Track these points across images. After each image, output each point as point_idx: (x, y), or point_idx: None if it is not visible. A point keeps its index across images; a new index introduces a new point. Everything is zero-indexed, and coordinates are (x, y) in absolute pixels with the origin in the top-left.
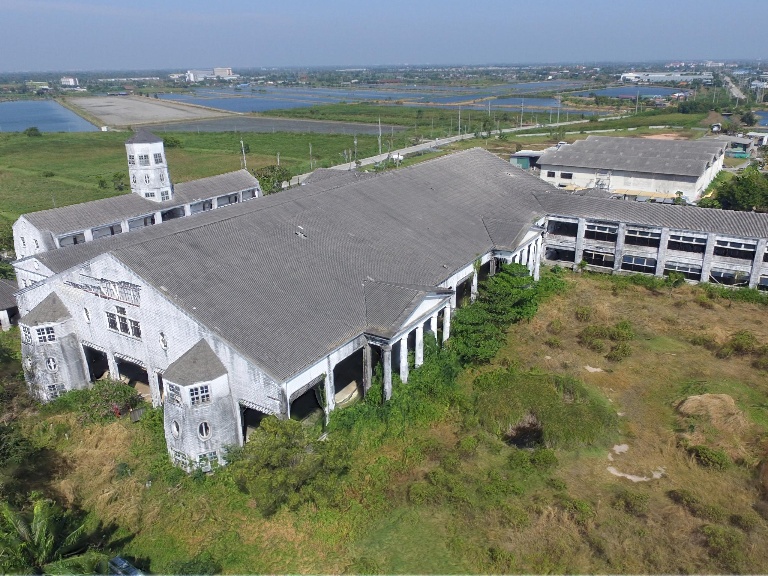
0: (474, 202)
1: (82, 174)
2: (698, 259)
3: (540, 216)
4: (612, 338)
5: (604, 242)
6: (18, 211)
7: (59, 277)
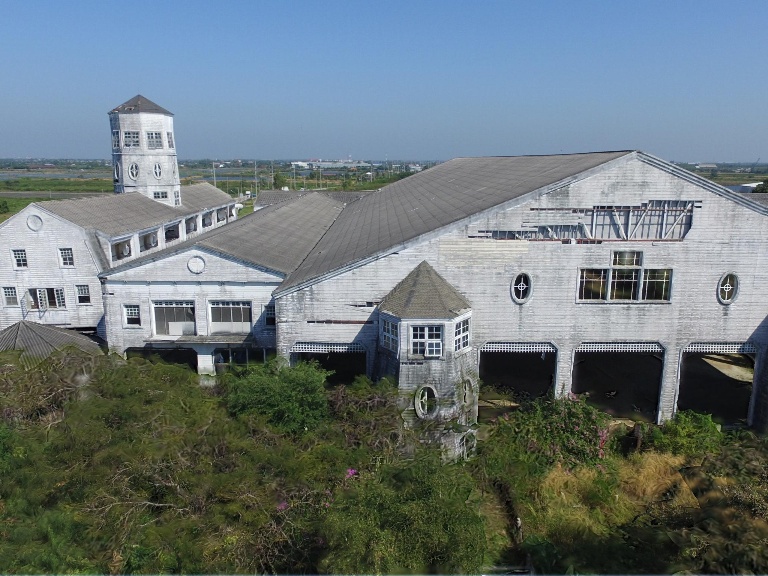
0: None
1: None
2: None
3: None
4: None
5: None
6: None
7: (459, 226)
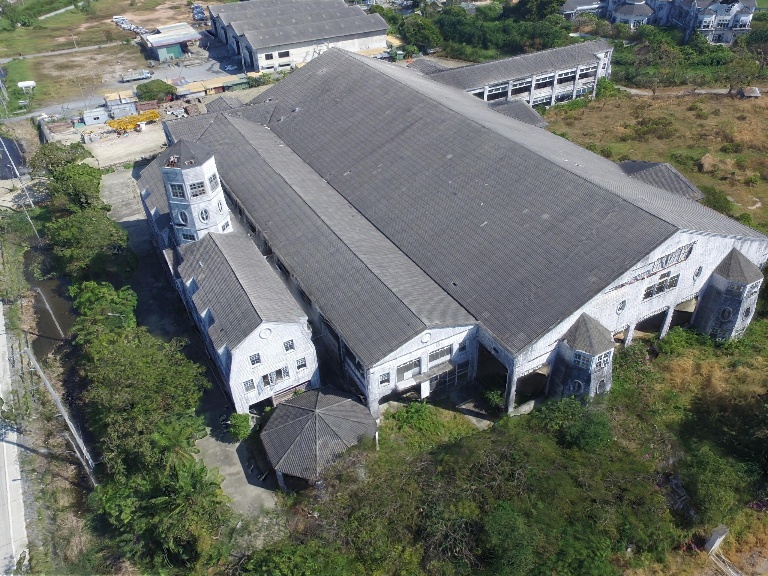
0: None
1: None
2: (550, 91)
3: None
4: (607, 157)
5: None
6: None
7: None
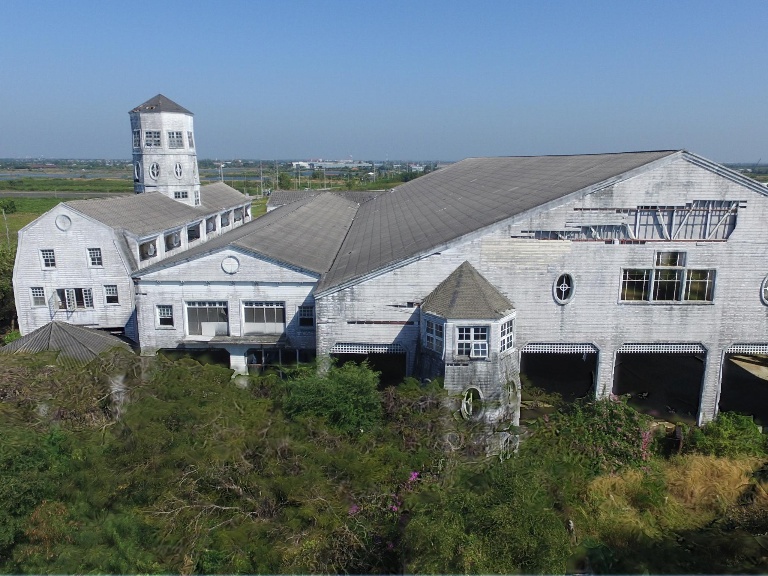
0: None
1: None
2: None
3: None
4: None
5: None
6: None
7: (502, 227)
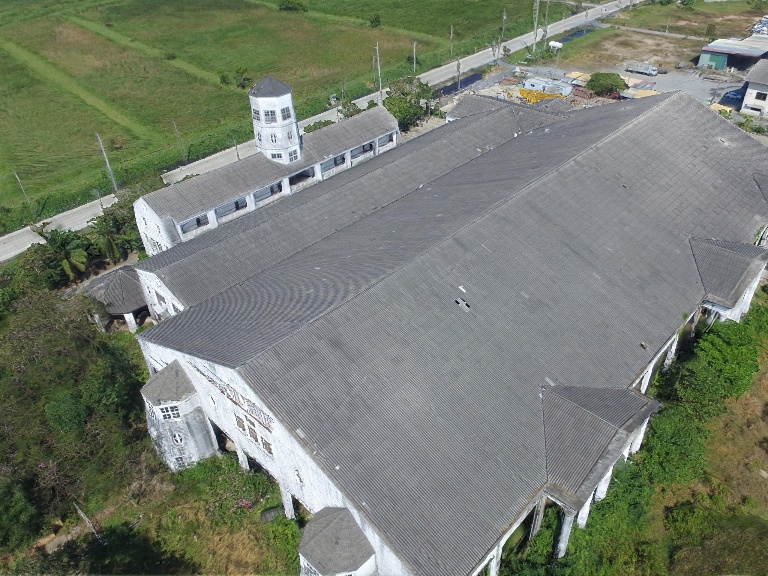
0: (678, 207)
1: (203, 57)
2: None
3: (765, 225)
4: None
5: None
6: (141, 121)
7: (181, 353)
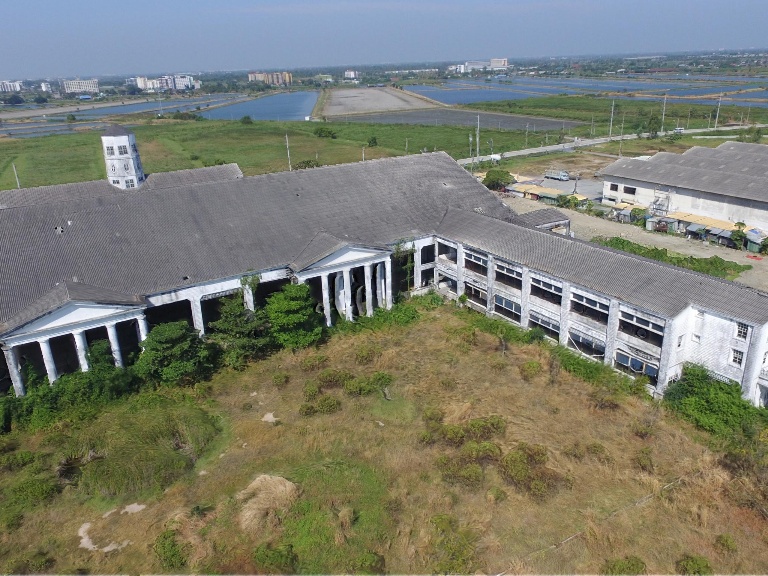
0: (337, 213)
1: None
2: (557, 313)
3: (415, 236)
4: None
5: (479, 275)
6: None
7: None
